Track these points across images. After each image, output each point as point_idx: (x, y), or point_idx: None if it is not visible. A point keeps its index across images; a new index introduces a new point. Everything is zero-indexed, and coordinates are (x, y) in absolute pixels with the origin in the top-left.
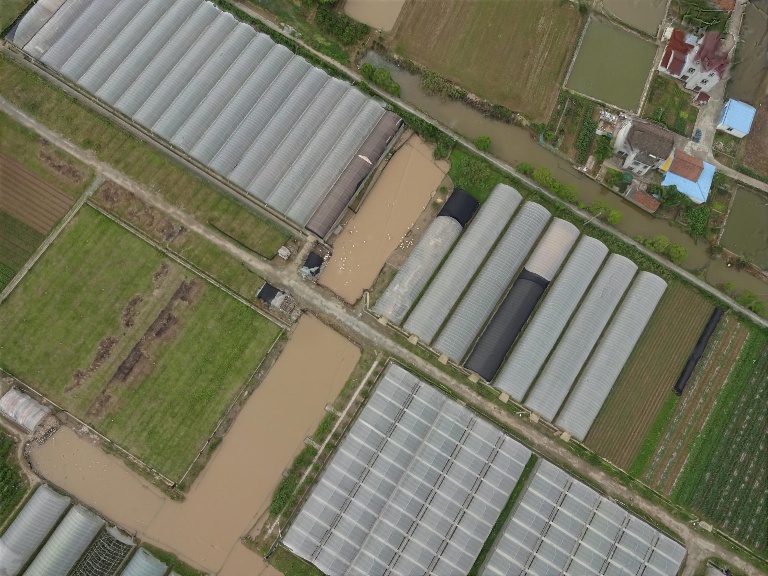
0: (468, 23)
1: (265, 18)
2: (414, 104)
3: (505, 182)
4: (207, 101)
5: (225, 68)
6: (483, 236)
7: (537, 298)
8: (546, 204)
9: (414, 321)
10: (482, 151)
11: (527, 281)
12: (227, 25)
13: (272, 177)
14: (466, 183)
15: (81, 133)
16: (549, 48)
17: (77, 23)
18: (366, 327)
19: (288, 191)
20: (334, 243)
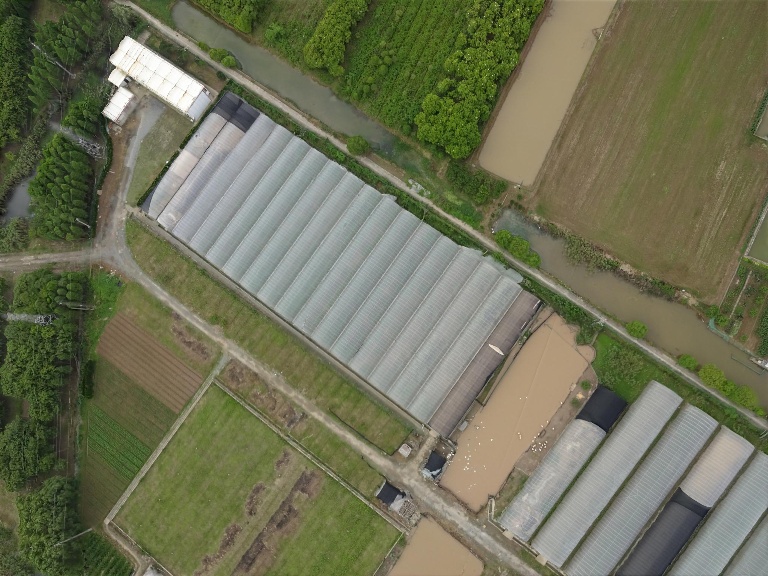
0: (626, 172)
1: (392, 174)
2: (555, 276)
3: (661, 378)
4: (330, 278)
5: (349, 239)
6: (631, 449)
7: (693, 527)
8: (712, 408)
9: (544, 543)
10: (635, 337)
11: (682, 507)
12: (352, 190)
13: (394, 367)
14: (613, 379)
15: (209, 307)
16: (729, 203)
17: (206, 192)
18: (490, 540)
19: (411, 384)
20: (458, 439)
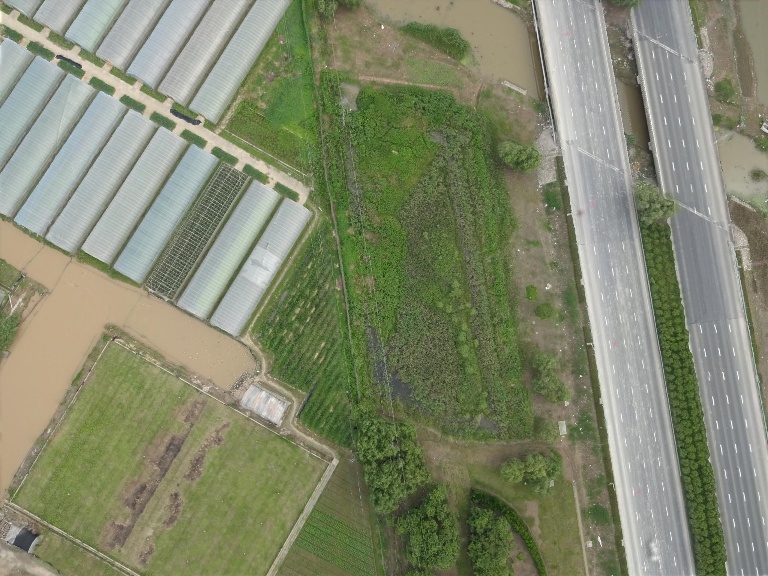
0: None
1: None
2: None
3: None
4: None
5: None
6: None
7: None
8: None
9: None
10: None
11: None
12: None
13: None
14: None
15: None
16: None
17: None
18: None
19: None
20: None
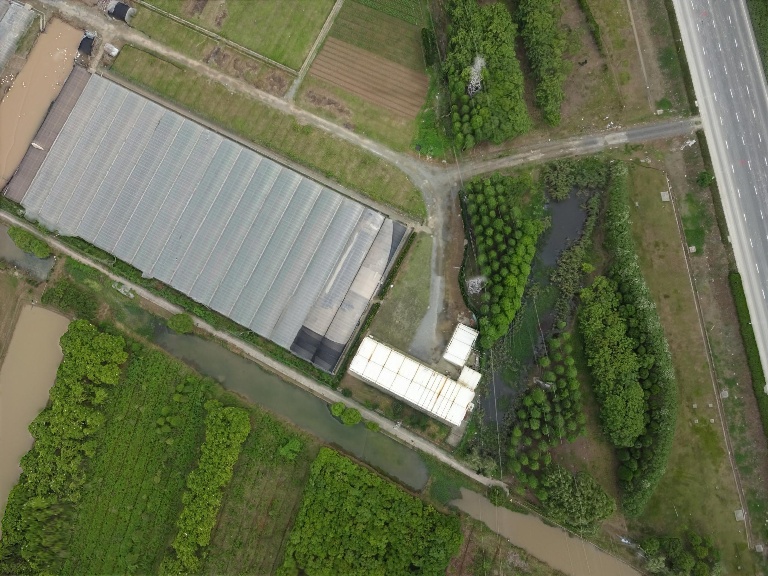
0: None
1: (151, 301)
2: (1, 224)
3: None
4: (190, 184)
5: None
6: None
7: None
8: None
9: None
10: None
11: None
12: (179, 275)
13: (122, 114)
14: None
15: (315, 141)
16: None
17: (332, 253)
18: None
19: (106, 102)
20: None
